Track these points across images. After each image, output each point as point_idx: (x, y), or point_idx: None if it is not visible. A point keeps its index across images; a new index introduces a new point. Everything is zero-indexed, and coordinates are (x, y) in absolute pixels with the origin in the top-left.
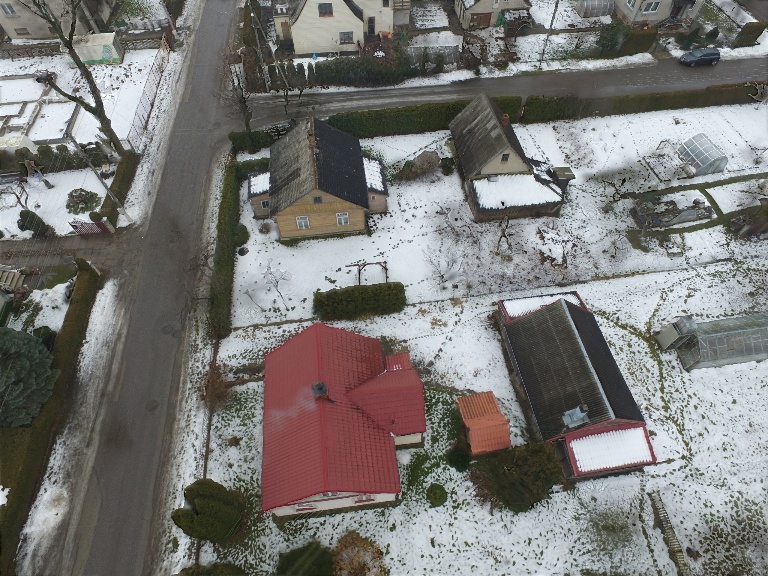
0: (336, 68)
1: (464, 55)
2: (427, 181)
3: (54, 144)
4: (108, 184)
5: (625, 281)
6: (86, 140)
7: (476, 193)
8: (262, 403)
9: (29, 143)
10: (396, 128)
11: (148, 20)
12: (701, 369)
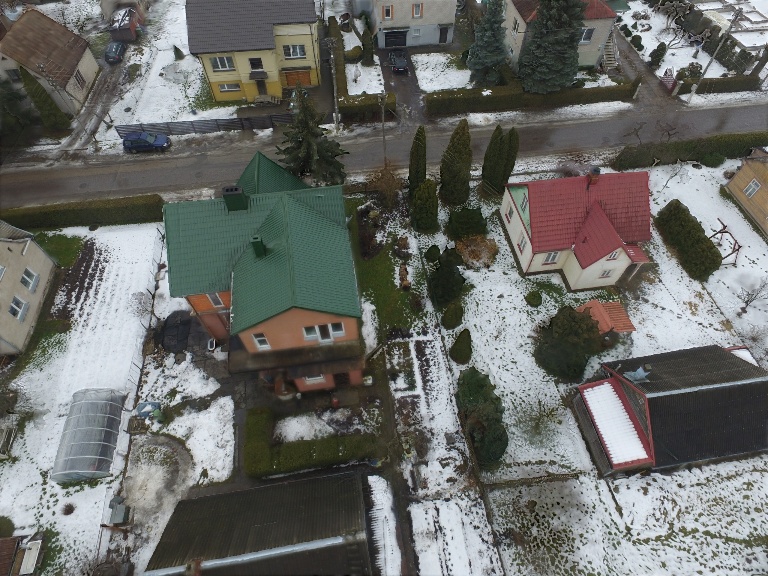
0: None
1: None
2: None
3: (737, 46)
4: None
5: None
6: None
7: None
8: None
9: None
10: None
11: None
12: None
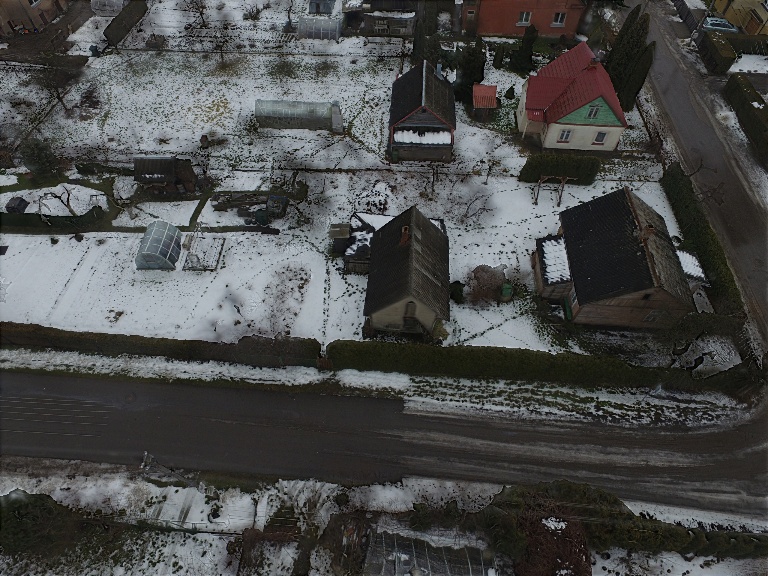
0: None
1: None
2: None
3: None
4: None
5: None
6: None
7: (442, 228)
8: None
9: None
10: None
11: None
12: None
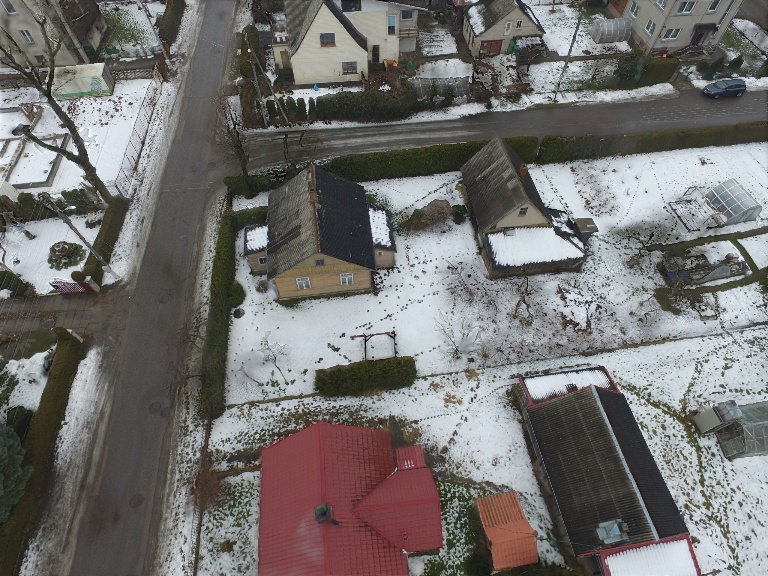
0: (339, 103)
1: (474, 87)
2: (437, 231)
3: (37, 188)
4: (94, 234)
5: (655, 349)
6: (72, 183)
7: (491, 248)
8: (258, 498)
9: (9, 189)
10: (403, 170)
11: (140, 47)
12: (744, 458)
